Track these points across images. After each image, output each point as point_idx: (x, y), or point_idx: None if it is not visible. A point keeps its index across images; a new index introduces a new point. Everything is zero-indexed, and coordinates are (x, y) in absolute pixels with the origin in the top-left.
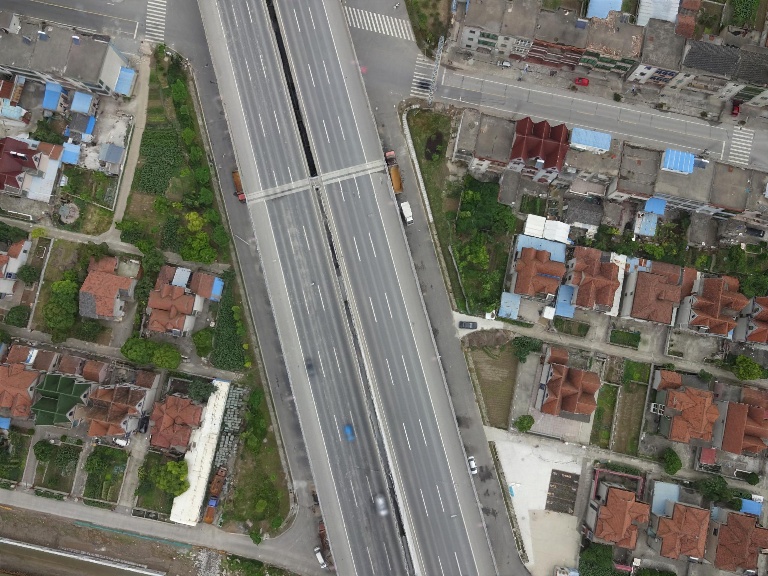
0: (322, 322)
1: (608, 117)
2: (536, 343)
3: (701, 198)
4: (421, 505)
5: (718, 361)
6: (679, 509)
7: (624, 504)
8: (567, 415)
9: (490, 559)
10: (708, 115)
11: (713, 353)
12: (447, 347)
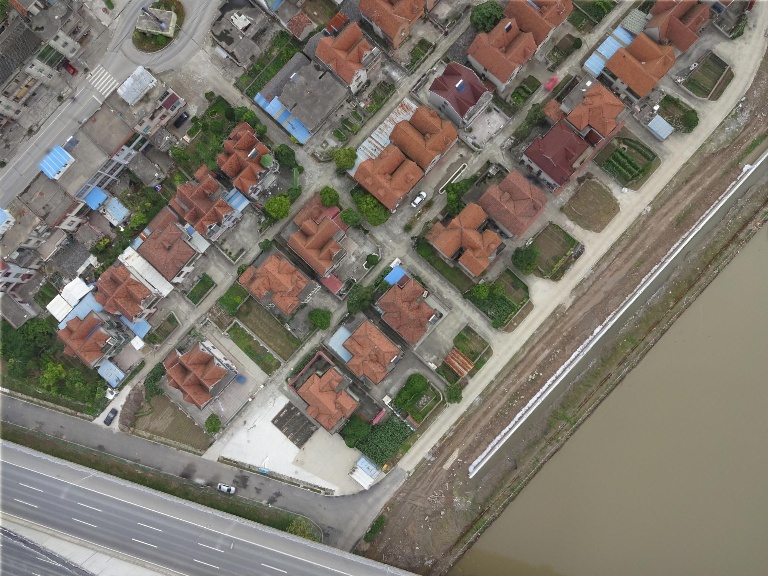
0: (10, 554)
1: (13, 182)
2: (157, 369)
3: (102, 161)
4: (206, 568)
5: (262, 225)
6: (347, 345)
7: (309, 393)
8: (218, 389)
9: (284, 538)
10: (62, 96)
11: (258, 222)
12: (119, 446)
